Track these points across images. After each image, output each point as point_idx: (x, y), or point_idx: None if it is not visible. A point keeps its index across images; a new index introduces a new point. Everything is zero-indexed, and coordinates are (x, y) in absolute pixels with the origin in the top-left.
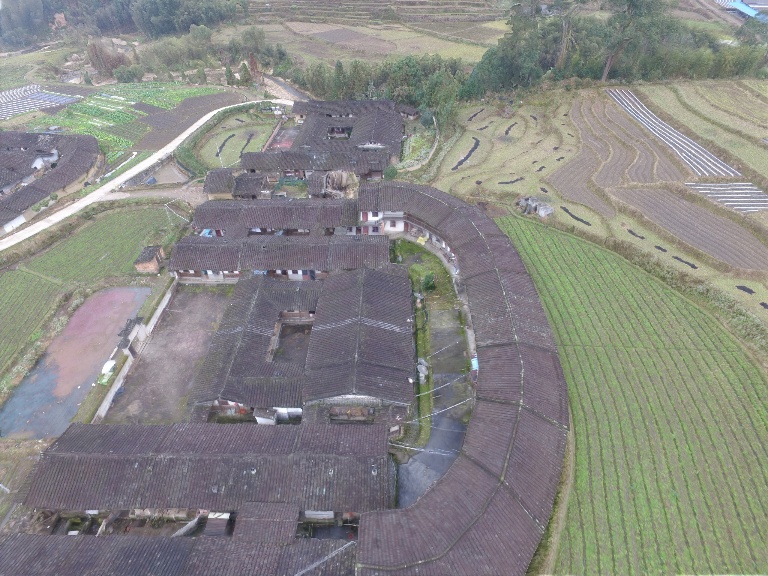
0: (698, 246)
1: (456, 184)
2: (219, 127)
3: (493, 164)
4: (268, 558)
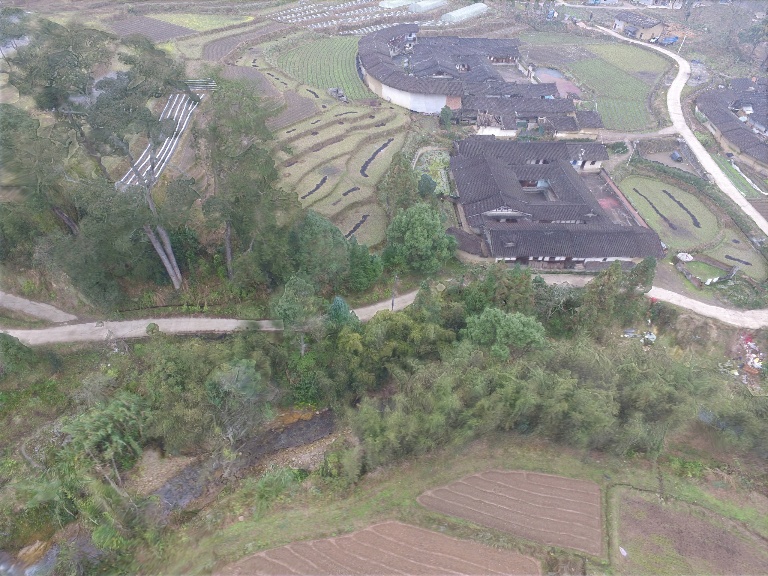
0: (259, 73)
1: (391, 115)
2: (743, 241)
3: (354, 138)
4: (440, 40)
